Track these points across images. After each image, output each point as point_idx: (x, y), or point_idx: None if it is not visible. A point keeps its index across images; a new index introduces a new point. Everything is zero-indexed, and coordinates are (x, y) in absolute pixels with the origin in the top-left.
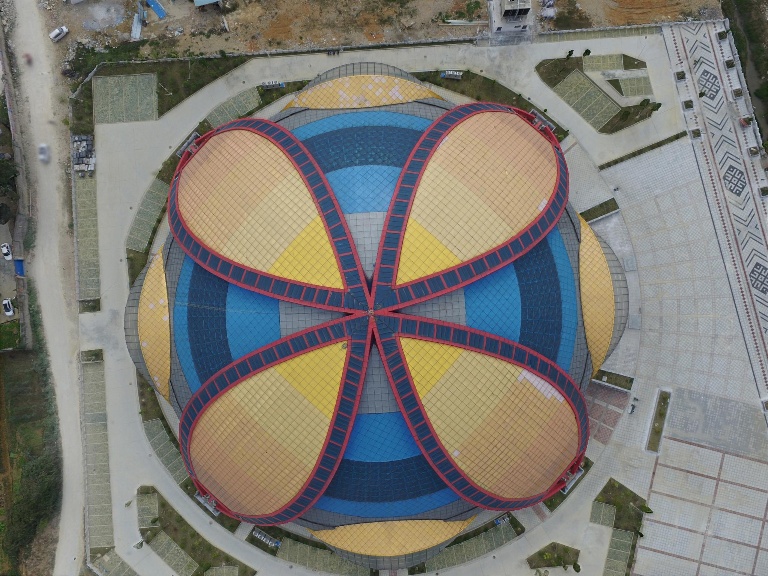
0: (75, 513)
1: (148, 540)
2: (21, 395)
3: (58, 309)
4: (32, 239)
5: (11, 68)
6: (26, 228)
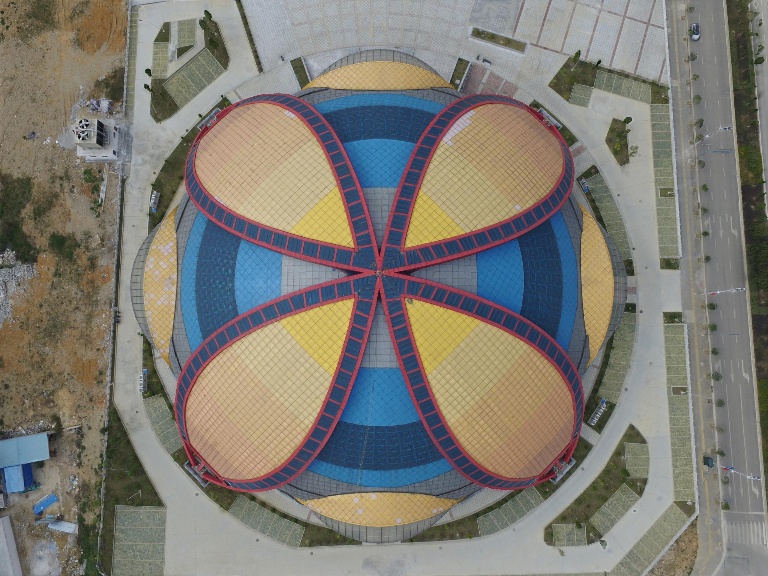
0: None
1: (599, 536)
2: None
3: None
4: None
5: None
6: None
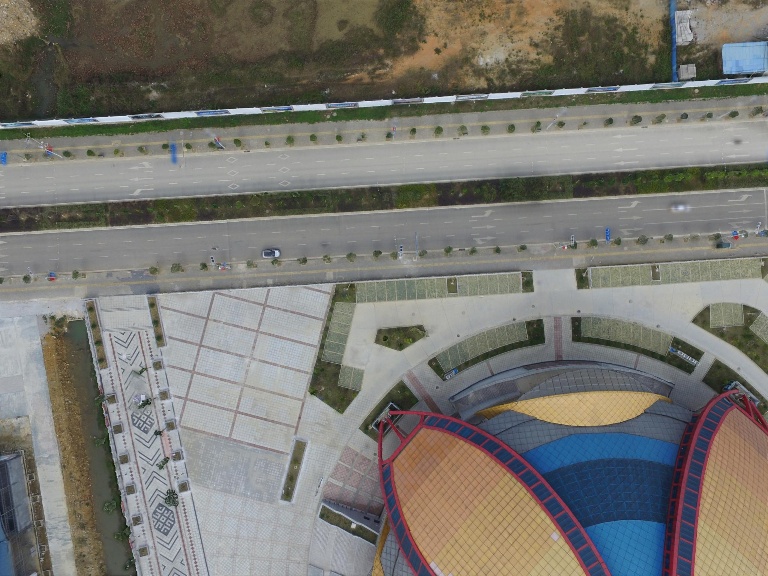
0: None
1: None
2: None
3: None
4: None
5: None
6: None
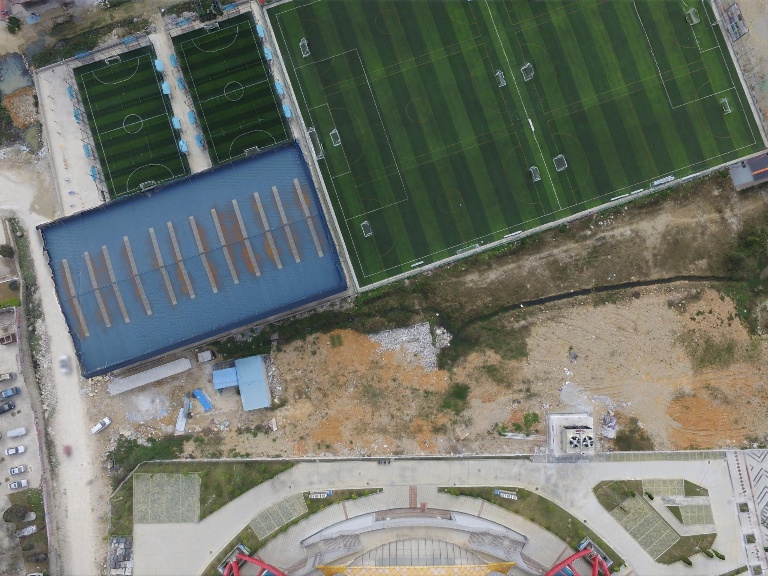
0: None
1: None
2: None
3: None
4: None
5: (50, 458)
6: None
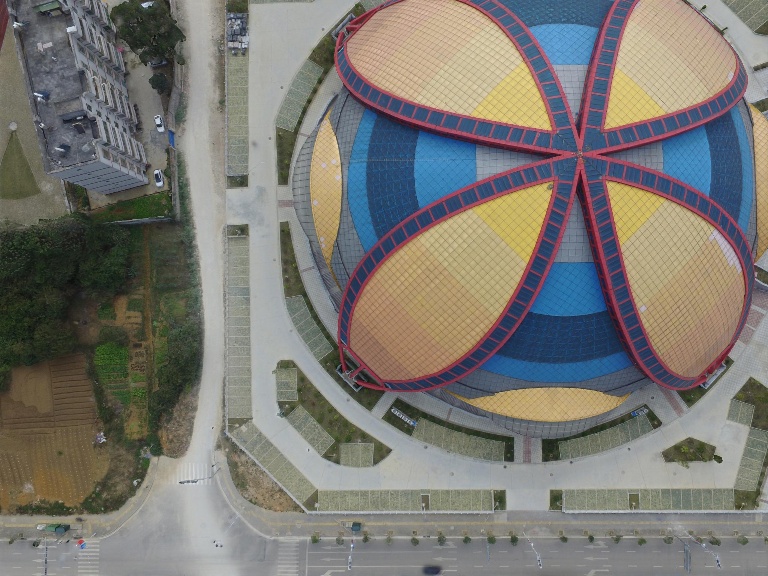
0: (214, 384)
1: (286, 413)
2: (168, 264)
3: (206, 183)
4: (183, 113)
5: None
6: (178, 102)
